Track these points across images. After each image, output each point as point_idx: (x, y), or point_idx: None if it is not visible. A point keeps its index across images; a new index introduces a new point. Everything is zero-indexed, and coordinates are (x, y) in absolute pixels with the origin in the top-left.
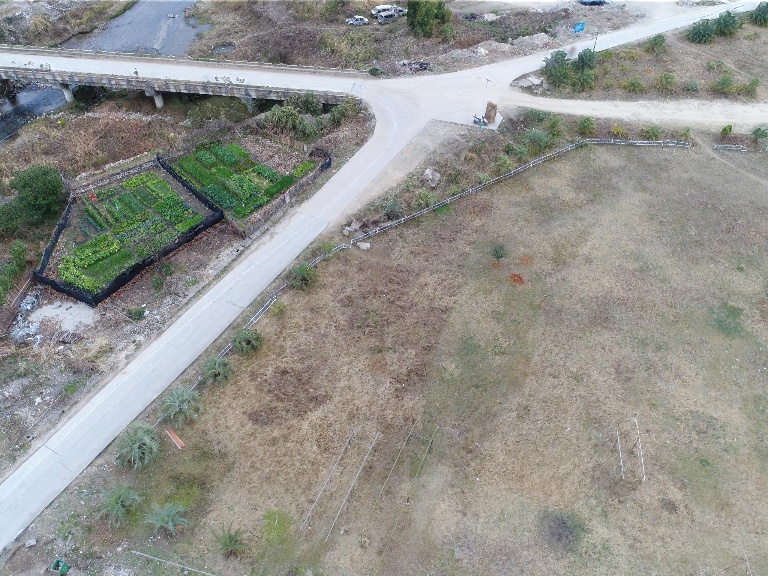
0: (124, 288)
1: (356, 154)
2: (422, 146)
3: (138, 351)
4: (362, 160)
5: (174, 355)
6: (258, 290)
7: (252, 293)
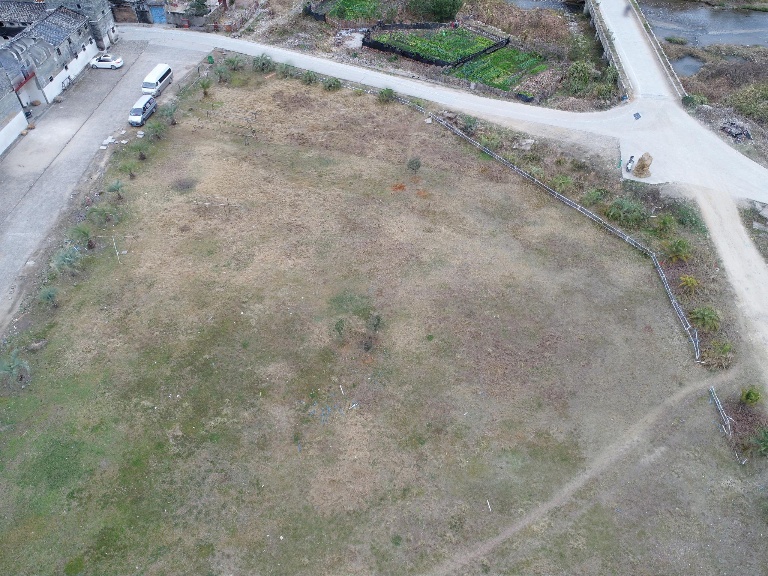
0: (378, 51)
1: (544, 108)
2: (568, 135)
3: (326, 58)
4: (536, 111)
5: (323, 67)
6: (376, 85)
7: (373, 84)
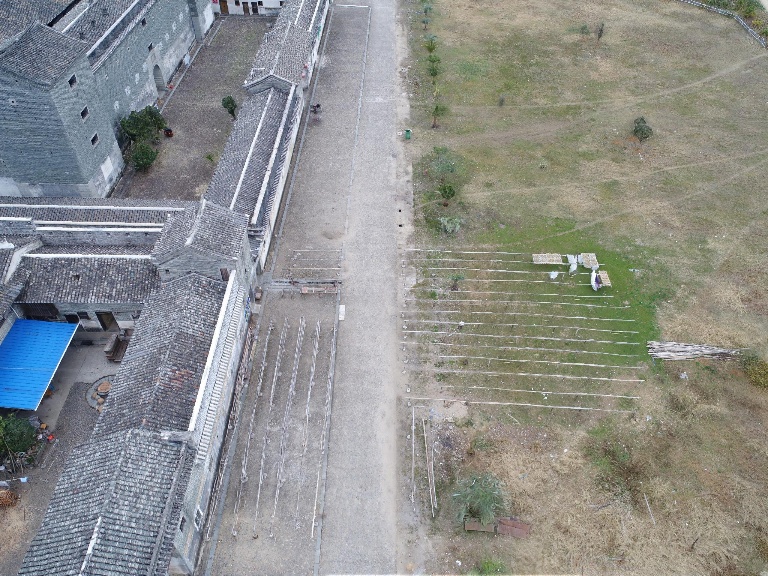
0: None
1: None
2: None
3: None
4: None
5: None
6: None
7: None
